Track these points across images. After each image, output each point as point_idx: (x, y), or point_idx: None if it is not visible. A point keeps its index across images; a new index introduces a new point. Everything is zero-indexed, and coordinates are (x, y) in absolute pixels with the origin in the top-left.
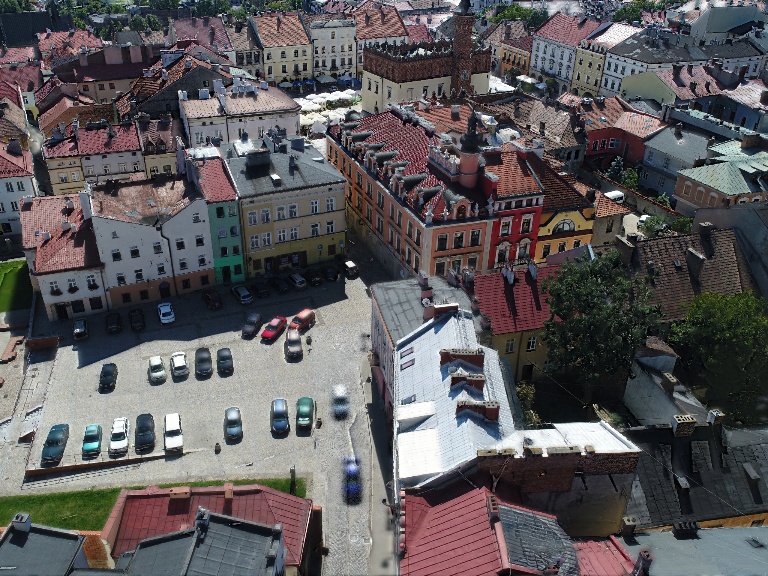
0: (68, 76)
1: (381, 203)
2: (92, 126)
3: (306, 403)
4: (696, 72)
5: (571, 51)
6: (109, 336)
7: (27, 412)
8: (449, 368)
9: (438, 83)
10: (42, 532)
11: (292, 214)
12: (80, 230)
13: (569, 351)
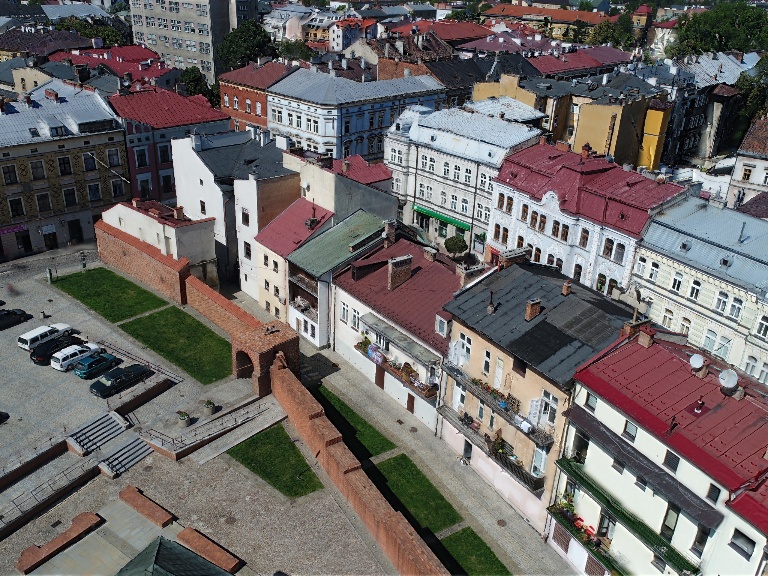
0: None
1: None
2: None
3: None
4: None
5: None
6: None
7: (85, 450)
8: None
9: None
10: None
11: None
12: None
13: None
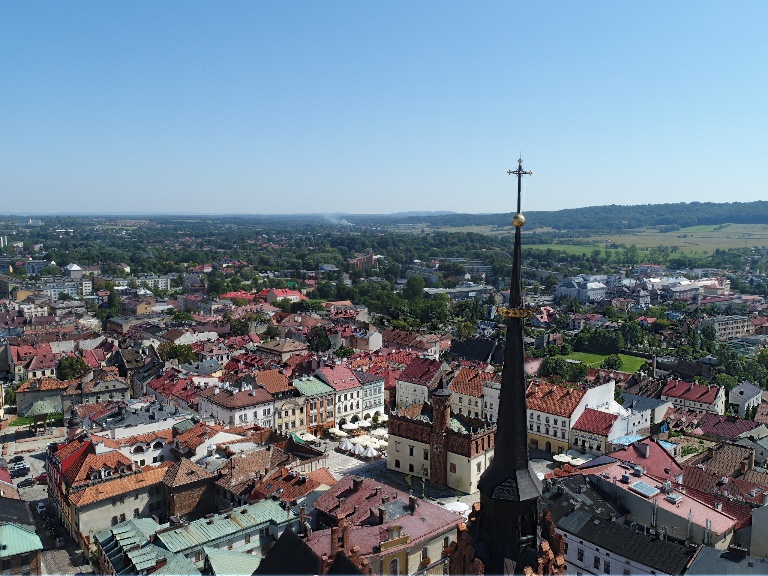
0: None
1: None
2: None
3: None
4: (380, 498)
5: None
6: None
7: None
8: None
9: (424, 448)
10: None
11: None
12: None
13: None
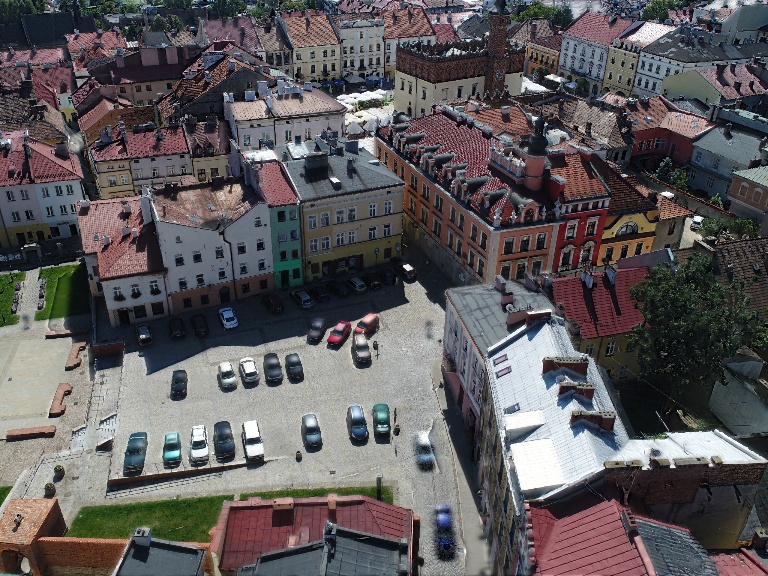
0: (105, 78)
1: (439, 206)
2: (139, 129)
3: (382, 410)
4: (739, 71)
5: (603, 50)
6: (173, 342)
7: (101, 420)
8: (557, 377)
9: (472, 83)
10: (162, 546)
11: (351, 217)
12: (141, 235)
13: (662, 357)
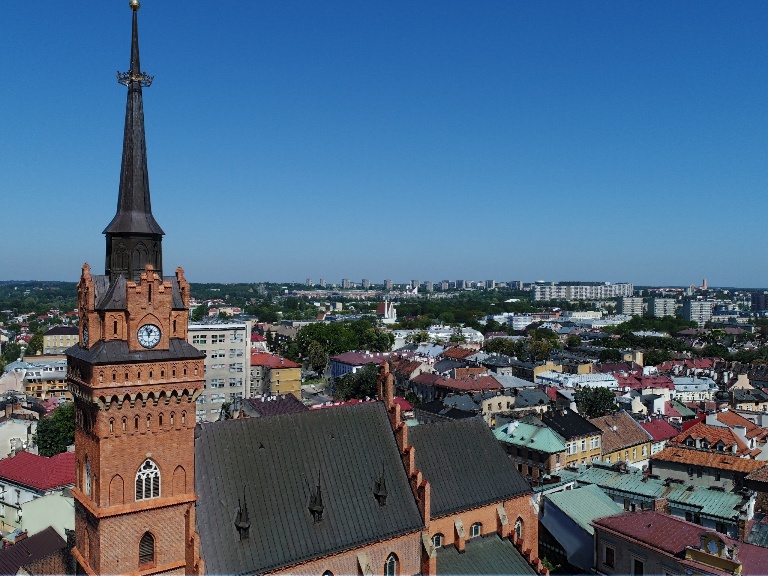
0: None
1: None
2: None
3: None
4: None
5: None
6: None
7: None
8: None
9: None
10: None
11: None
12: None
13: None
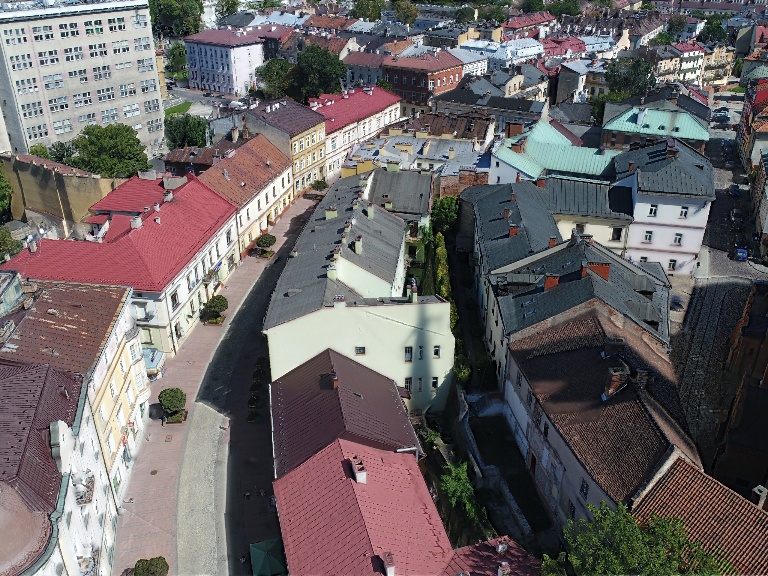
0: None
1: None
2: None
3: None
4: None
5: None
6: None
7: None
8: None
9: None
10: None
11: None
12: None
13: None
